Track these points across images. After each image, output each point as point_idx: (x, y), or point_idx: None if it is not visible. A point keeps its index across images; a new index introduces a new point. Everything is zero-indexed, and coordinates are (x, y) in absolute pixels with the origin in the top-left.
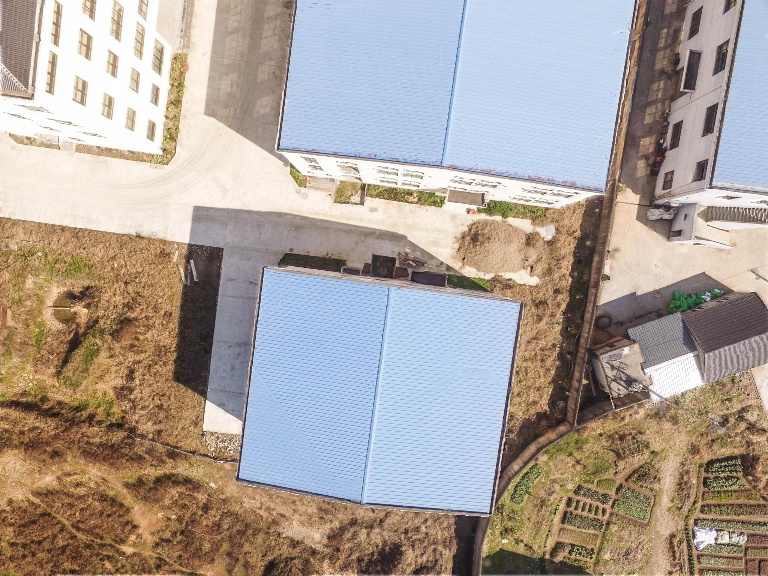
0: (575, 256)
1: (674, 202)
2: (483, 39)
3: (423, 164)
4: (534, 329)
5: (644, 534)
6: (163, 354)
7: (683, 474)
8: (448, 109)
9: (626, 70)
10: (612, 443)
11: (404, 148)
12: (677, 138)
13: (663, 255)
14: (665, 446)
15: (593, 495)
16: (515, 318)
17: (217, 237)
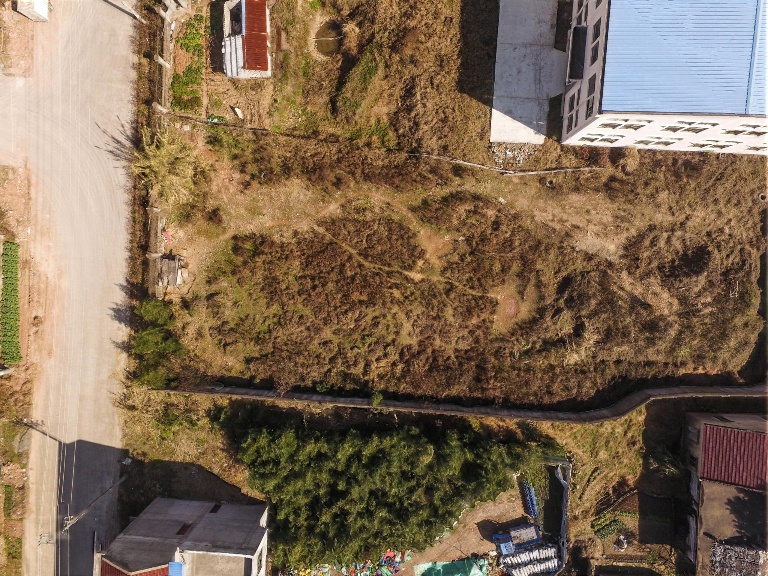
0: None
1: None
2: None
3: None
4: None
5: None
6: (446, 62)
7: None
8: None
9: None
10: None
11: None
12: None
13: None
14: None
15: None
16: None
17: None
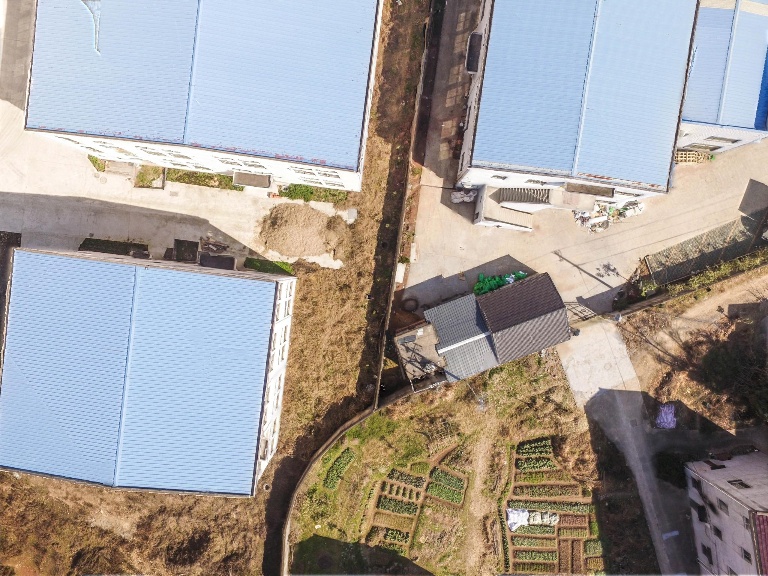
0: (378, 239)
1: (467, 184)
2: (218, 16)
3: (163, 142)
4: (339, 313)
5: (458, 517)
6: None
7: (494, 456)
8: (188, 86)
9: (373, 48)
10: (423, 426)
11: (147, 126)
12: (468, 120)
13: (468, 238)
14: (476, 428)
15: (406, 478)
16: (270, 297)
17: (14, 222)
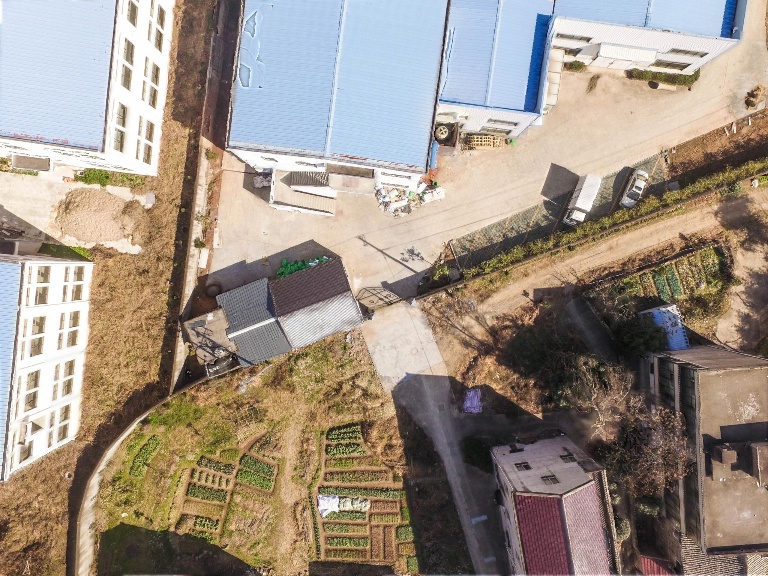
0: (177, 224)
1: (258, 168)
2: None
3: None
4: (139, 298)
5: (268, 503)
6: None
7: (304, 442)
8: None
9: (115, 27)
10: (230, 412)
11: None
12: None
13: (271, 223)
14: (285, 414)
15: (215, 466)
16: (16, 279)
17: None
